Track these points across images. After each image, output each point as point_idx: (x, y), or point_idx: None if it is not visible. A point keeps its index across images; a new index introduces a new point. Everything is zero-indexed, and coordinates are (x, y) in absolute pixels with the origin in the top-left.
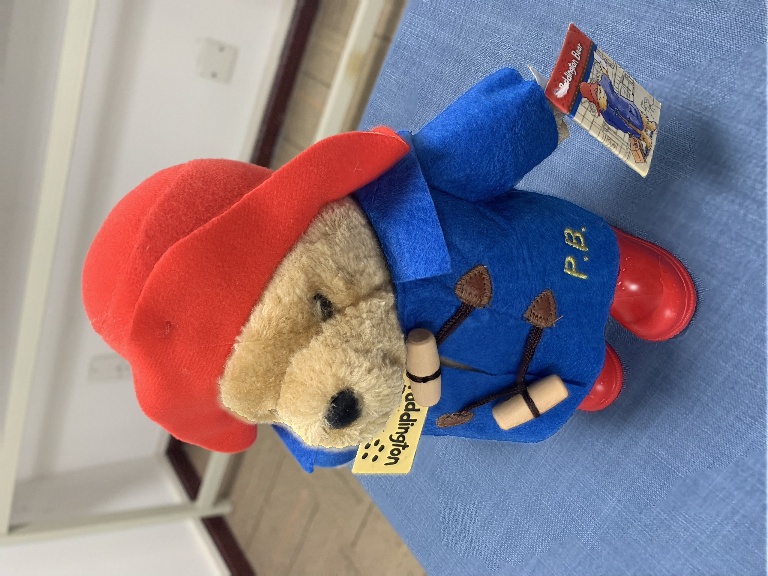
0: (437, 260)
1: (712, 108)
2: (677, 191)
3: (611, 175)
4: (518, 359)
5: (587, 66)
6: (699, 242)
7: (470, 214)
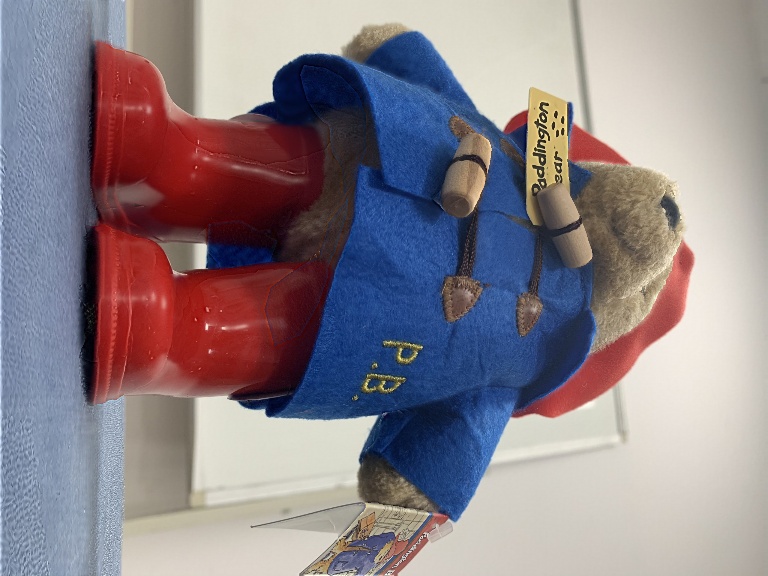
0: None
1: None
2: None
3: None
4: None
5: (382, 571)
6: None
7: None
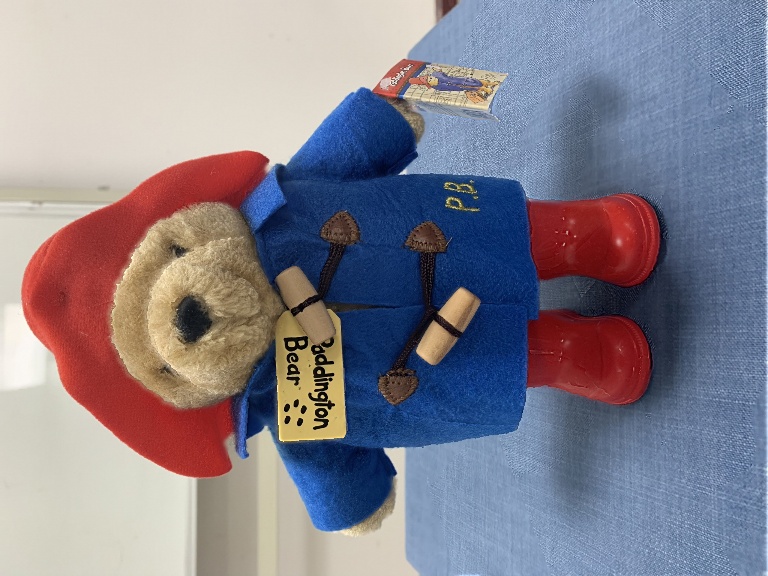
0: (274, 199)
1: (587, 70)
2: (598, 144)
3: (554, 175)
4: (420, 288)
5: (417, 71)
6: (633, 166)
7: (327, 183)
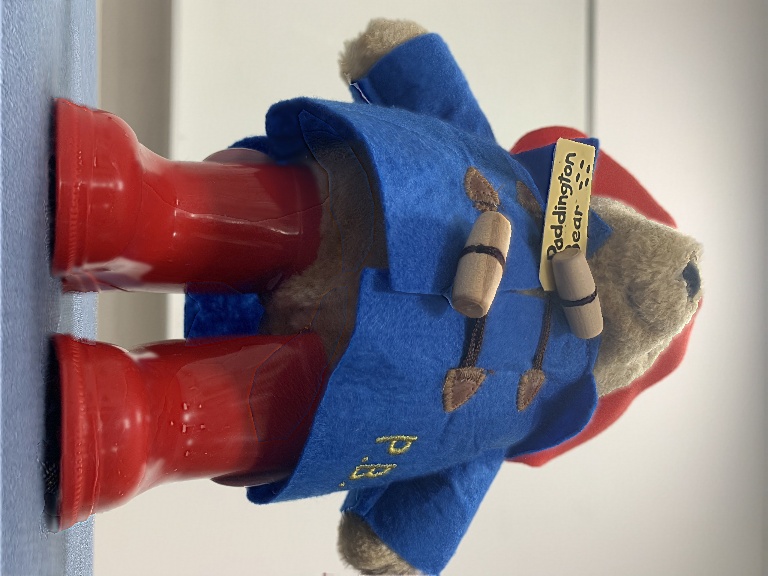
0: None
1: None
2: None
3: None
4: None
5: None
6: None
7: None
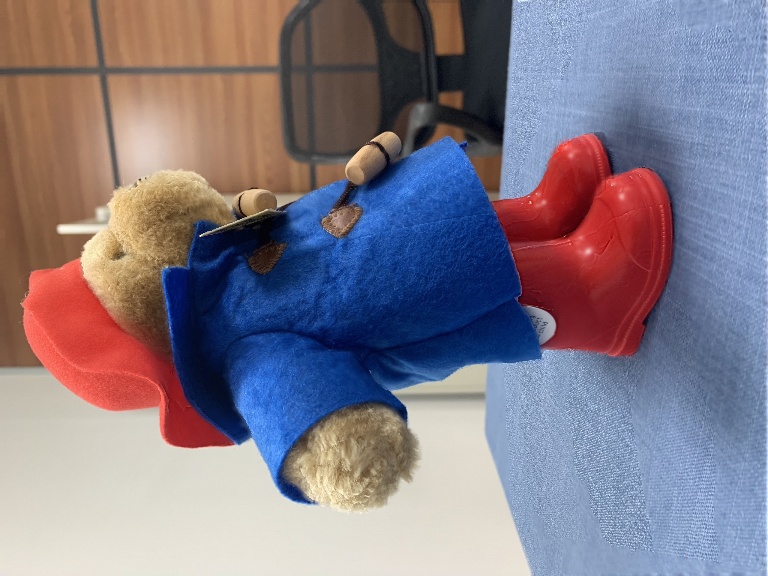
0: None
1: None
2: None
3: None
4: None
5: None
6: None
7: None
